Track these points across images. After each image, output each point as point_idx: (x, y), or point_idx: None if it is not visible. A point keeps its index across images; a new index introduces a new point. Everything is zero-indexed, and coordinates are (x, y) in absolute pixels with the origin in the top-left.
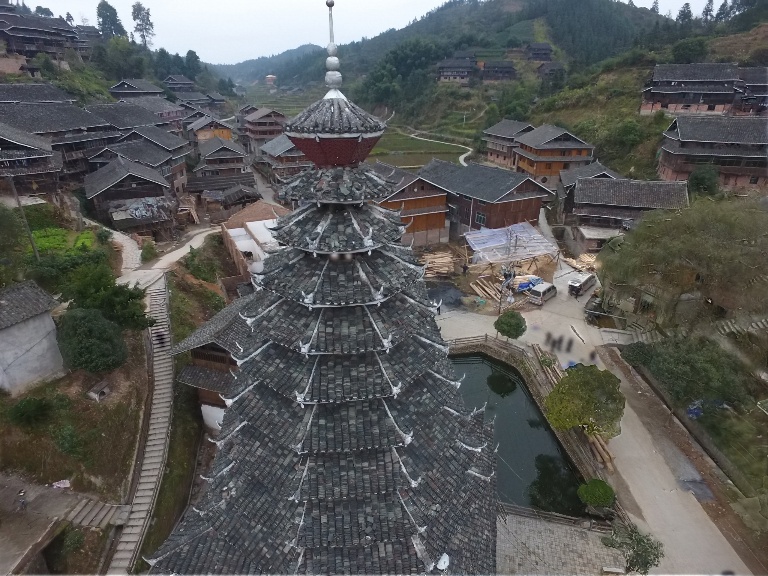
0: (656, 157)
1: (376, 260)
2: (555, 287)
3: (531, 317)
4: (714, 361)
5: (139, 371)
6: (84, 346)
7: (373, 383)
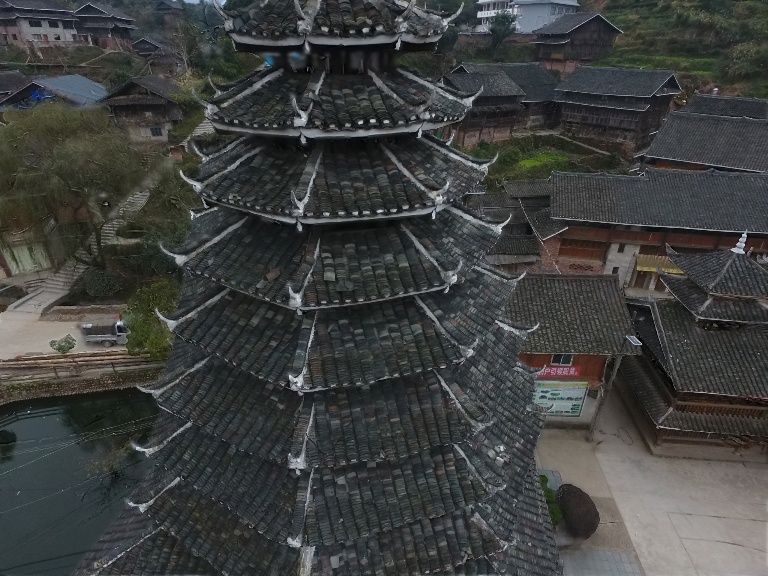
0: None
1: None
2: None
3: None
4: (190, 227)
5: None
6: None
7: None
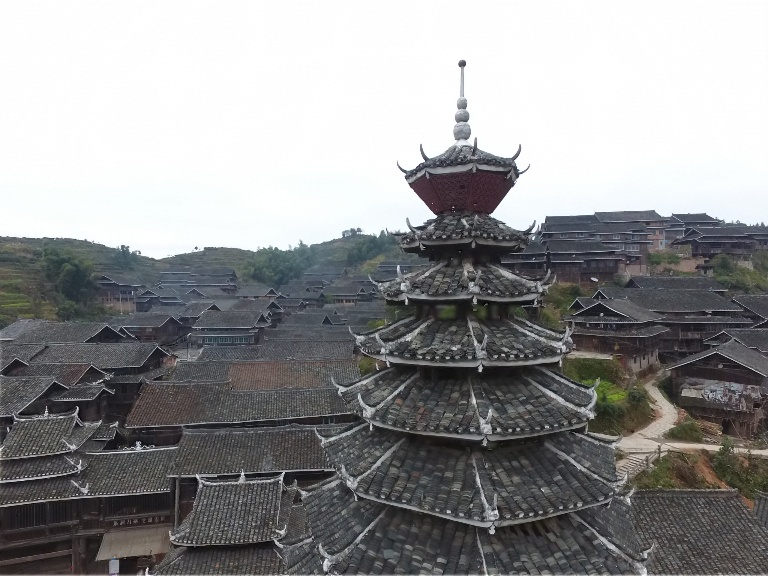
0: None
1: (450, 327)
2: None
3: None
4: None
5: None
6: None
7: None
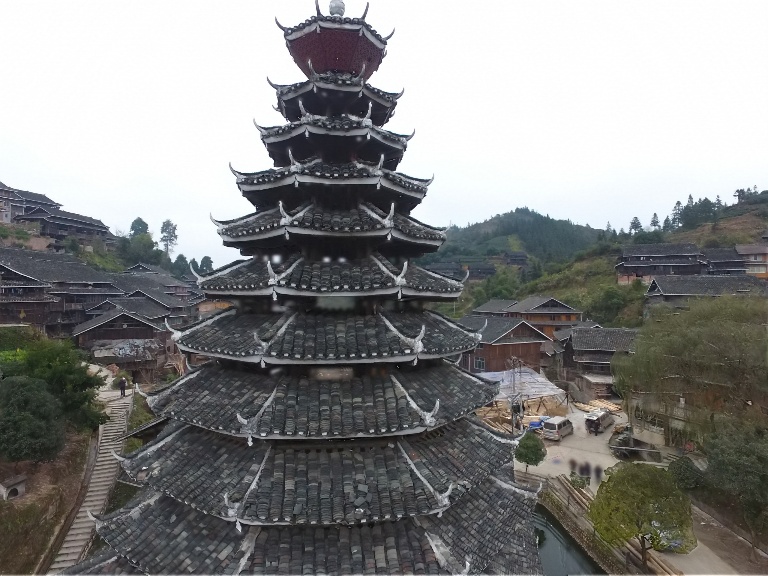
0: (644, 317)
1: None
2: (570, 422)
3: (549, 452)
4: None
5: (72, 480)
6: (12, 419)
7: (370, 279)
